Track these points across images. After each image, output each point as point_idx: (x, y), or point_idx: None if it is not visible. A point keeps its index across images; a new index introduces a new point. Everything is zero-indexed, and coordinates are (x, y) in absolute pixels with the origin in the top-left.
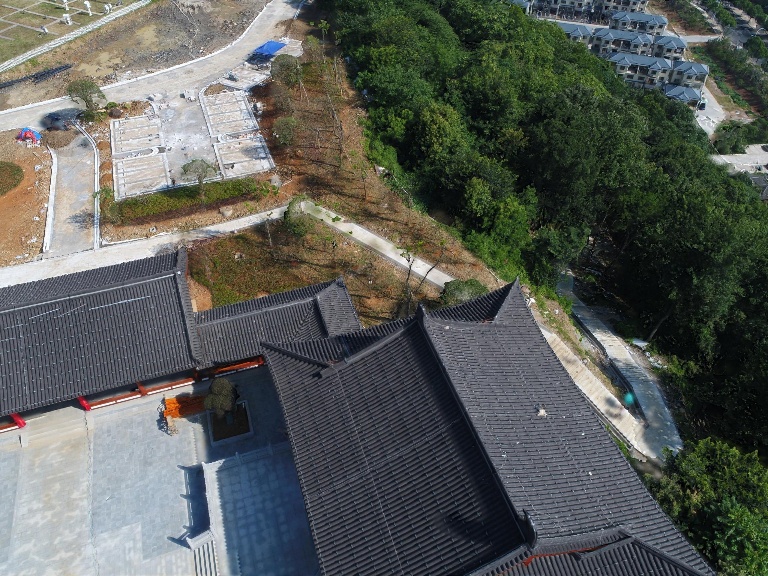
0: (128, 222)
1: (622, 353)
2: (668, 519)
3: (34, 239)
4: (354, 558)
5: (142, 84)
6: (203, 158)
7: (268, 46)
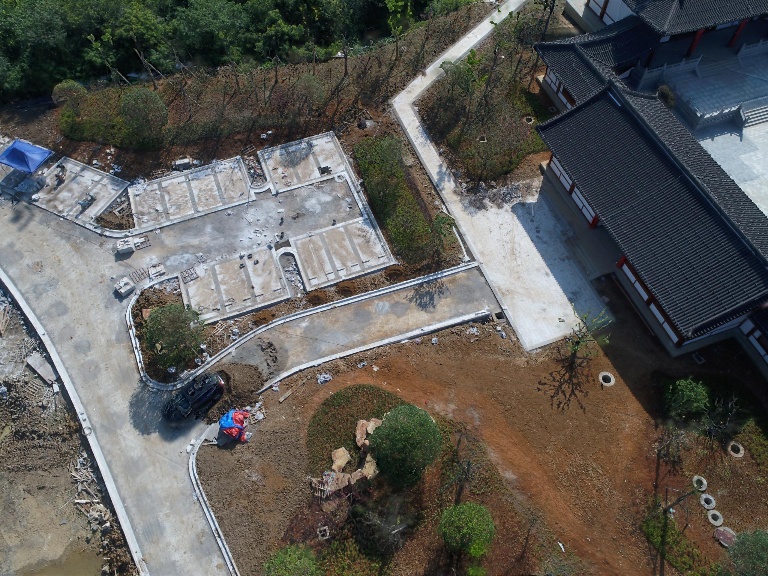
0: None
1: None
2: None
3: (471, 330)
4: None
5: (65, 322)
6: (304, 199)
7: (28, 152)
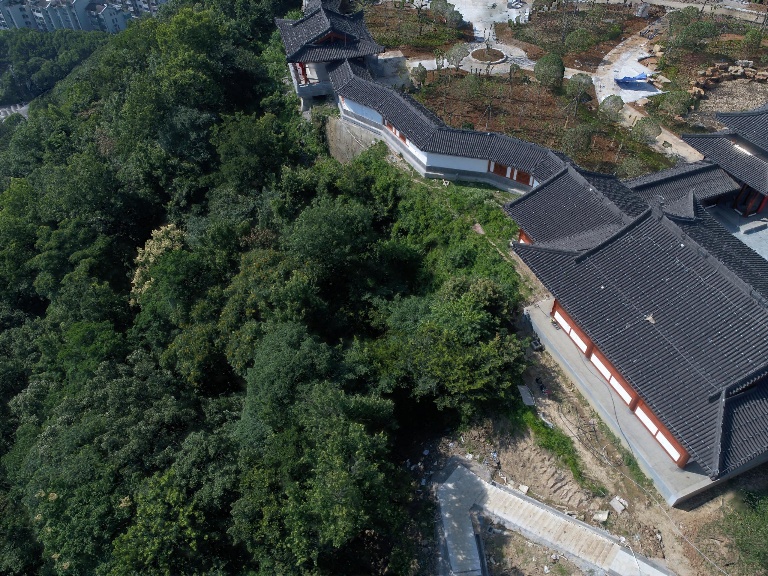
0: None
1: None
2: (543, 279)
3: None
4: None
5: None
6: None
7: None
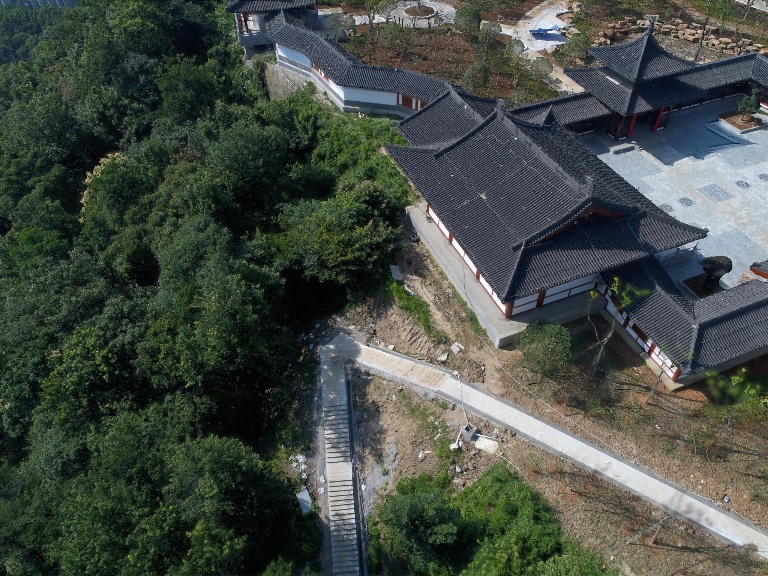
0: None
1: (335, 470)
2: (408, 172)
3: None
4: None
5: None
6: None
7: None
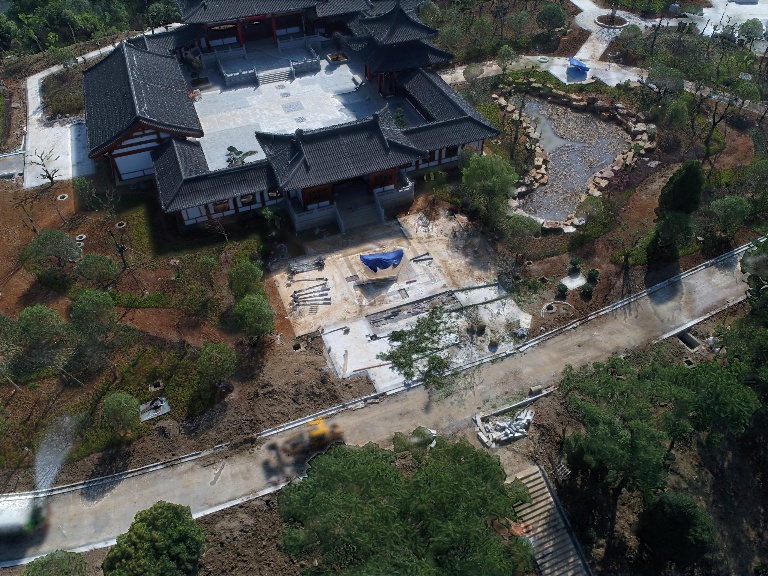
0: (3, 140)
1: None
2: None
3: None
4: (279, 3)
5: None
6: None
7: None
